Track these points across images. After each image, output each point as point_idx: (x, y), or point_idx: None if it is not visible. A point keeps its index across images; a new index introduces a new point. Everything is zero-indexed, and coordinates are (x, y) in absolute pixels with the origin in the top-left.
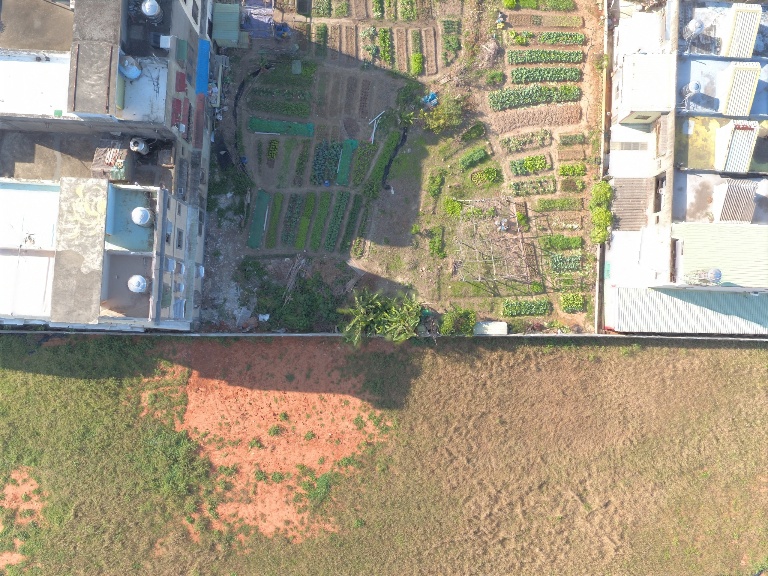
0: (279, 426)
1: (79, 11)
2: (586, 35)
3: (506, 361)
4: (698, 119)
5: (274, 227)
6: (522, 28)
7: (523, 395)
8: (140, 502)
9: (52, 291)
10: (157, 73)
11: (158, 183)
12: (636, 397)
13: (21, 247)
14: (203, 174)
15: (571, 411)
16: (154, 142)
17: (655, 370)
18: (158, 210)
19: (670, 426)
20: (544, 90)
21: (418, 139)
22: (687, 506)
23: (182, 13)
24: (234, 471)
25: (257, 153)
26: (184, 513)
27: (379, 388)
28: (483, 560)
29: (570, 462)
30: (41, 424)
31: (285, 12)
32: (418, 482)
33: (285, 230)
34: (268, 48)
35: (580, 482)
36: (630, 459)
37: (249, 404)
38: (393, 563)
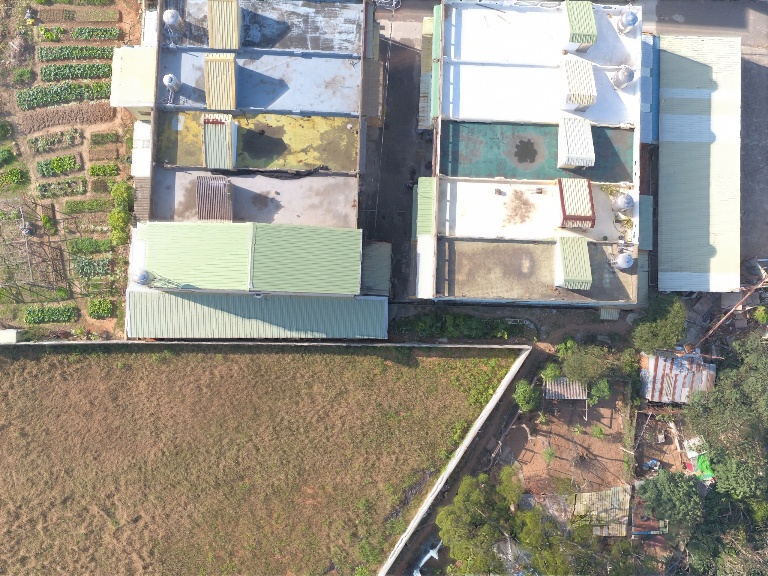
0: None
1: None
2: (123, 30)
3: (29, 370)
4: (188, 114)
5: None
6: (54, 24)
7: (47, 406)
8: None
9: None
10: None
11: None
12: (170, 406)
13: None
14: None
15: (100, 422)
16: None
17: (190, 377)
18: None
19: (206, 436)
20: (74, 87)
21: None
22: (224, 520)
23: None
24: None
25: None
26: None
27: None
28: None
29: (96, 475)
30: None
31: None
32: None
33: None
34: None
35: (107, 496)
36: (162, 471)
37: None
38: None
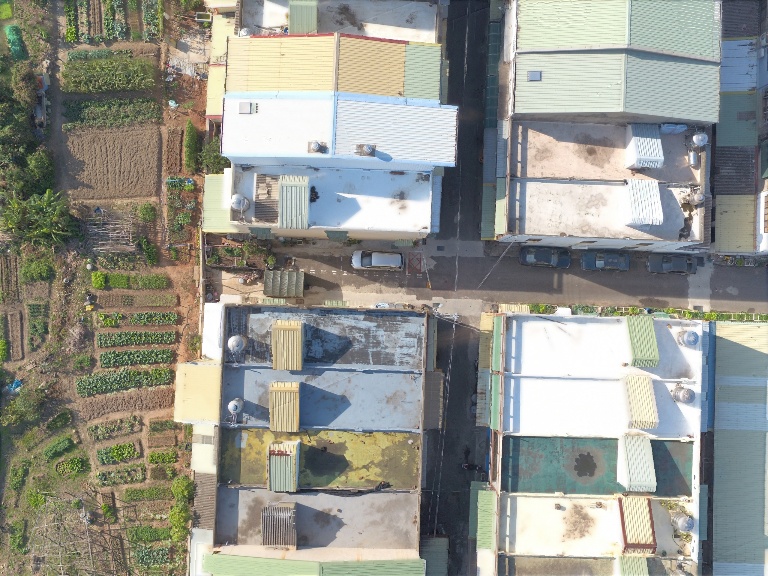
0: None
1: None
2: (181, 314)
3: None
4: (251, 431)
5: None
6: (113, 309)
7: None
8: None
9: None
10: None
11: None
12: None
13: None
14: None
15: None
16: None
17: None
18: None
19: None
20: (133, 375)
21: (2, 429)
22: None
23: None
24: None
25: None
26: None
27: None
28: None
29: None
30: None
31: None
32: None
33: None
34: None
35: None
36: None
37: None
38: None
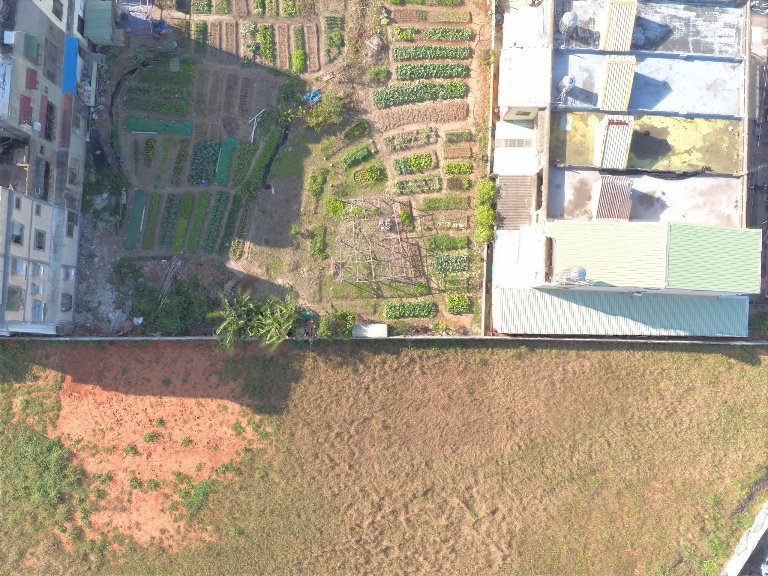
0: (154, 432)
1: None
2: (473, 30)
3: (390, 364)
4: (576, 114)
5: (151, 228)
6: (407, 24)
7: (407, 399)
8: (10, 511)
9: None
10: (3, 70)
11: (13, 183)
12: (525, 401)
13: None
14: (75, 174)
15: (457, 415)
16: (9, 141)
17: (544, 373)
18: None
19: (560, 430)
20: (429, 87)
21: (300, 137)
22: (578, 513)
23: (35, 9)
24: (108, 478)
25: (133, 153)
26: (55, 522)
27: (258, 393)
28: (365, 569)
29: (456, 468)
30: None
31: (164, 9)
32: (298, 489)
33: (162, 231)
34: (146, 46)
35: (466, 489)
36: (518, 465)
37: (124, 410)
38: (272, 573)
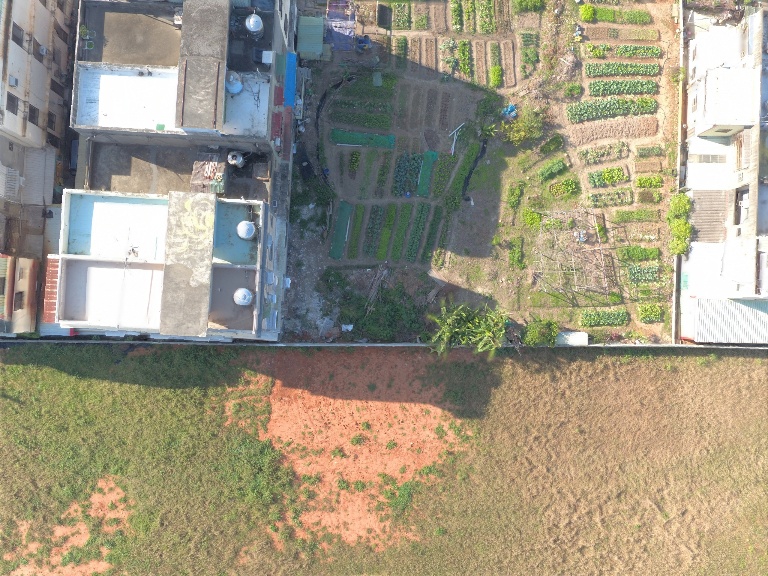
0: (361, 435)
1: (186, 27)
2: (662, 48)
3: (585, 371)
4: None
5: (356, 238)
6: (599, 41)
7: (601, 405)
8: (225, 511)
9: (161, 304)
10: (258, 88)
11: (253, 196)
12: (712, 407)
13: (127, 260)
14: (288, 186)
15: (648, 420)
16: (249, 155)
17: (731, 380)
18: (261, 224)
19: (746, 435)
20: (621, 103)
21: (497, 151)
22: (763, 515)
23: (279, 28)
24: (317, 480)
25: (339, 165)
26: (268, 521)
27: (460, 398)
28: (563, 568)
29: (648, 471)
30: (127, 433)
31: (365, 25)
32: (498, 491)
33: (367, 241)
34: (349, 60)
35: (658, 491)
36: (707, 468)
37: (332, 413)
38: (474, 571)
